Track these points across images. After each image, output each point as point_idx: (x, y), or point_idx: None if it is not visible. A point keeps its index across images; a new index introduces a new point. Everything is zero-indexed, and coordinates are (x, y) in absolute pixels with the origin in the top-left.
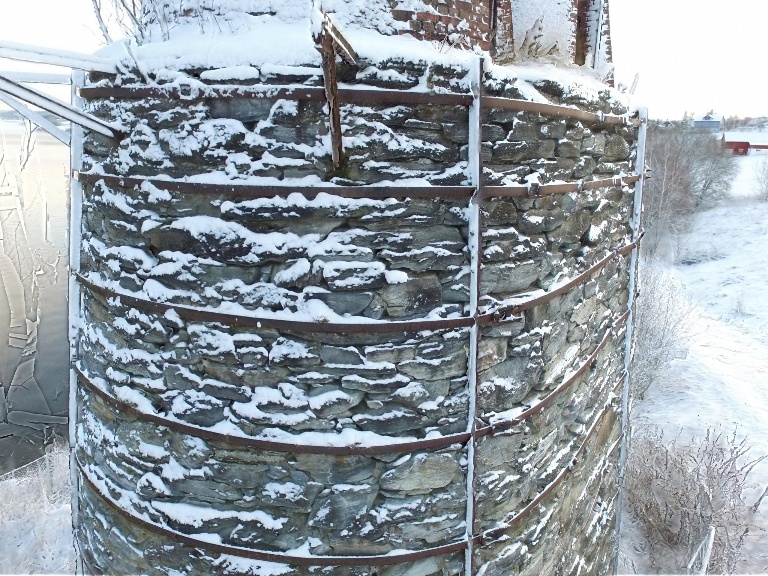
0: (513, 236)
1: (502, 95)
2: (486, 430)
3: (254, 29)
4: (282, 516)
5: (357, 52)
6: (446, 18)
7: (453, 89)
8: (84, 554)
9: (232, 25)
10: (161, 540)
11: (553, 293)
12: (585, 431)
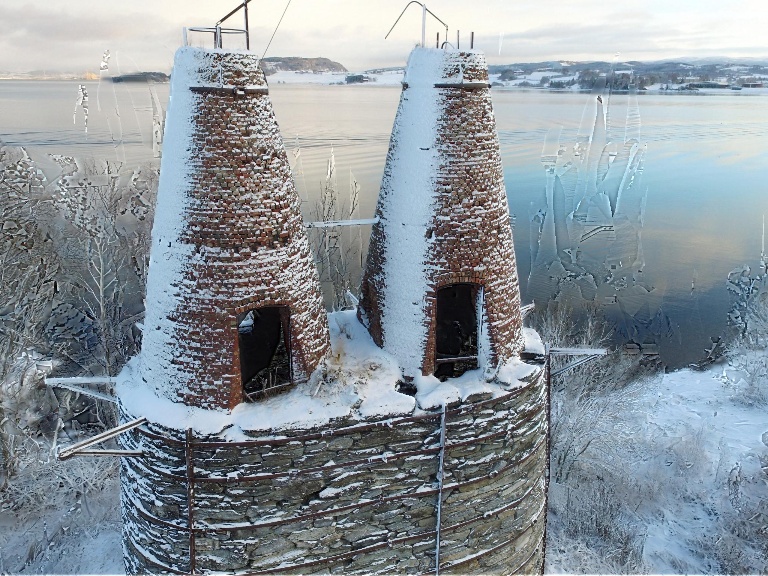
0: None
1: (209, 440)
2: (200, 575)
3: (140, 387)
4: (137, 569)
5: (146, 418)
6: (201, 397)
7: None
8: None
9: None
10: None
11: (256, 526)
12: None
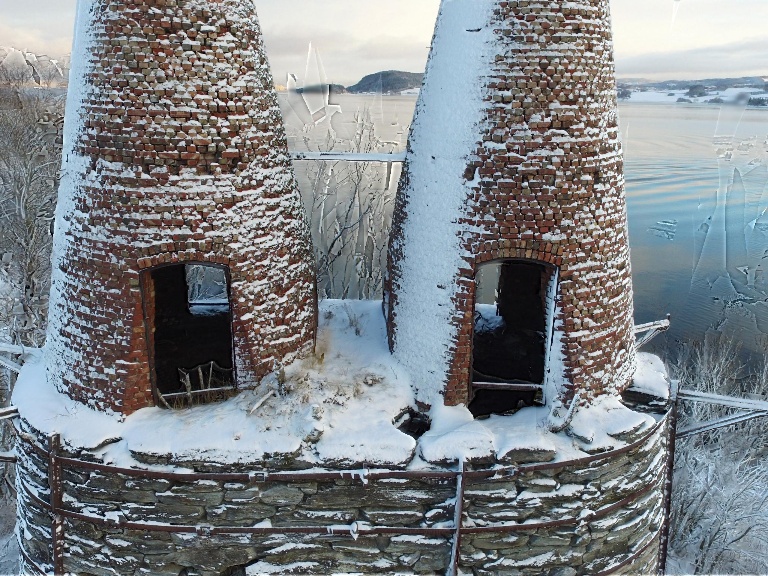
0: (92, 547)
1: None
2: None
3: (39, 364)
4: None
5: None
6: (87, 389)
7: None
8: None
9: (29, 362)
10: None
11: None
12: None
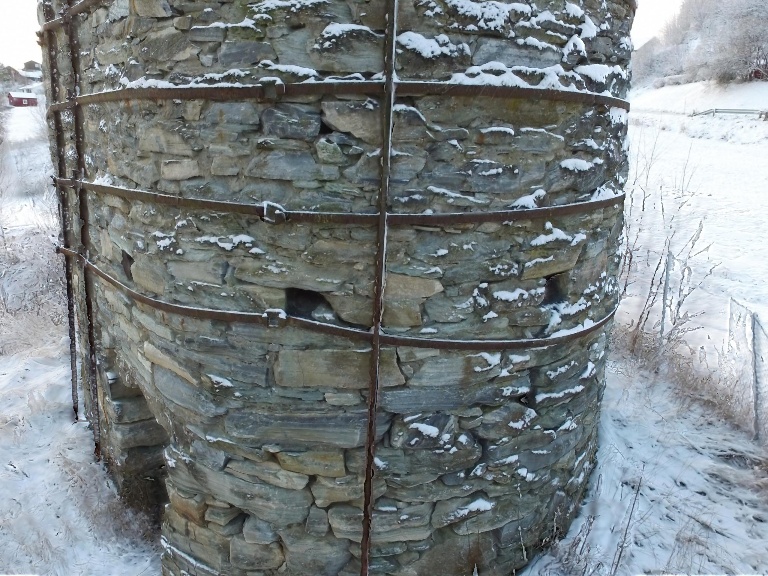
0: None
1: None
2: None
3: None
4: None
5: None
6: None
7: None
8: (442, 214)
9: None
10: (579, 112)
11: None
12: None
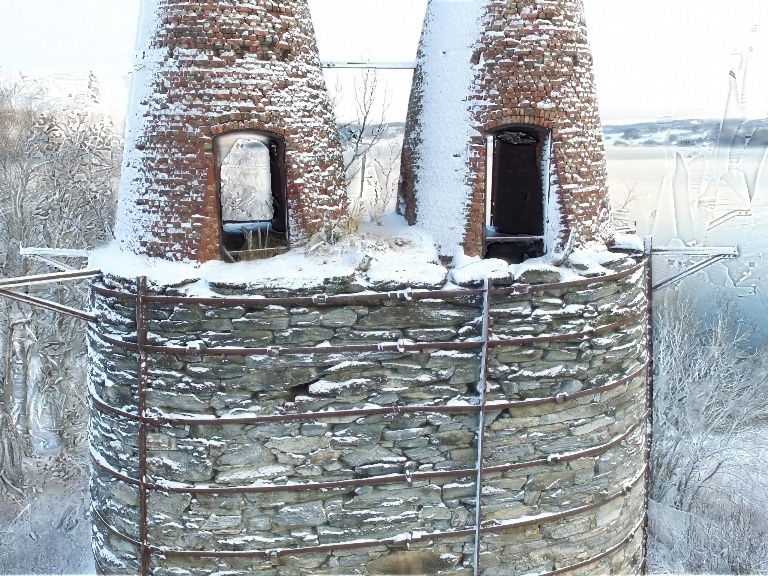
0: (174, 377)
1: (166, 294)
2: (151, 485)
3: None
4: None
5: None
6: (165, 244)
7: (132, 291)
8: None
9: (99, 246)
10: None
11: (222, 420)
12: (317, 541)
